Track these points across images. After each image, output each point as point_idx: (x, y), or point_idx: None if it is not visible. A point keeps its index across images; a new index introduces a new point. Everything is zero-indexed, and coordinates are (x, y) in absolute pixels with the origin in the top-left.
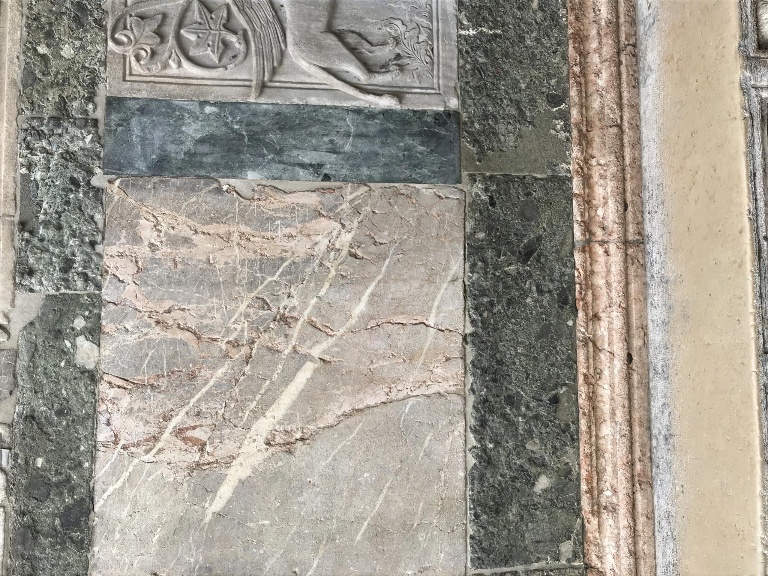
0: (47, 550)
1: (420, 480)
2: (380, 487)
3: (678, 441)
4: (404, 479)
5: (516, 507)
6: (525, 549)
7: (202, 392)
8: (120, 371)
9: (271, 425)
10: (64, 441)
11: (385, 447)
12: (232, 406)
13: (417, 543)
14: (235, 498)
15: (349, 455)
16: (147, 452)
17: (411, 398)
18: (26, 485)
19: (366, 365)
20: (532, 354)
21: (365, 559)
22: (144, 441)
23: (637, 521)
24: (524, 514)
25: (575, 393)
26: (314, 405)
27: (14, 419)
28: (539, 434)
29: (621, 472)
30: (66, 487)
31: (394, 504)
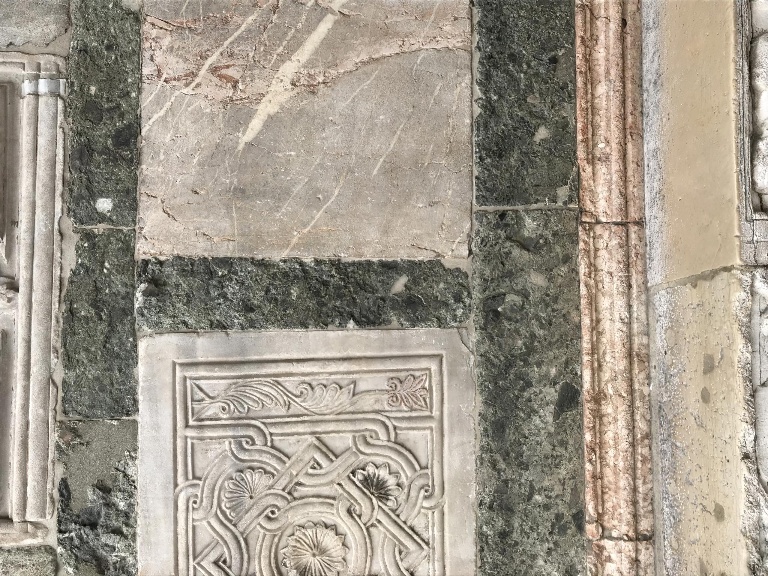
0: (101, 166)
1: (430, 125)
2: (394, 129)
3: (666, 76)
4: (416, 123)
5: (518, 153)
6: (525, 191)
7: (234, 36)
8: (161, 14)
9: (296, 68)
10: (114, 73)
11: (399, 93)
12: (261, 50)
13: (428, 180)
14: (265, 130)
15: (366, 98)
16: (187, 85)
17: (422, 51)
18: (82, 109)
19: (381, 20)
20: (534, 17)
21: (381, 191)
22: (184, 76)
23: (628, 169)
24: (525, 160)
25: (573, 56)
26: (335, 52)
27: (69, 53)
28: (539, 89)
29: (614, 124)
30: (116, 113)
31: (407, 145)
